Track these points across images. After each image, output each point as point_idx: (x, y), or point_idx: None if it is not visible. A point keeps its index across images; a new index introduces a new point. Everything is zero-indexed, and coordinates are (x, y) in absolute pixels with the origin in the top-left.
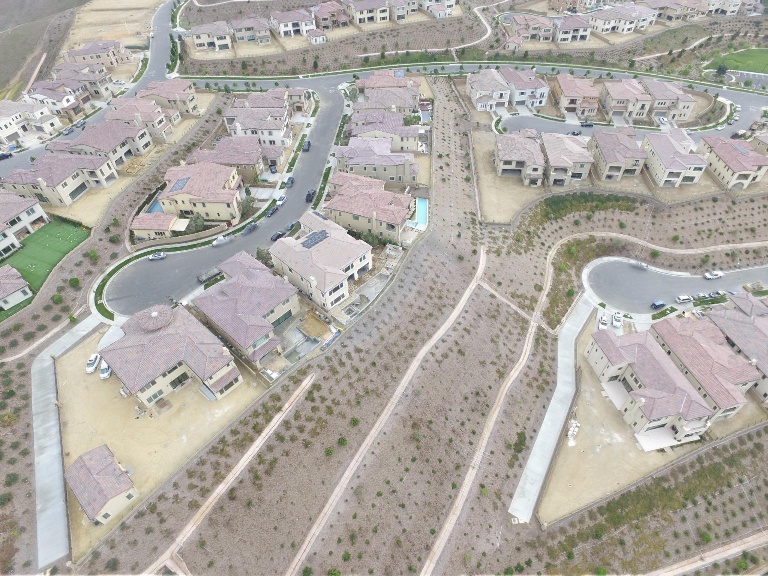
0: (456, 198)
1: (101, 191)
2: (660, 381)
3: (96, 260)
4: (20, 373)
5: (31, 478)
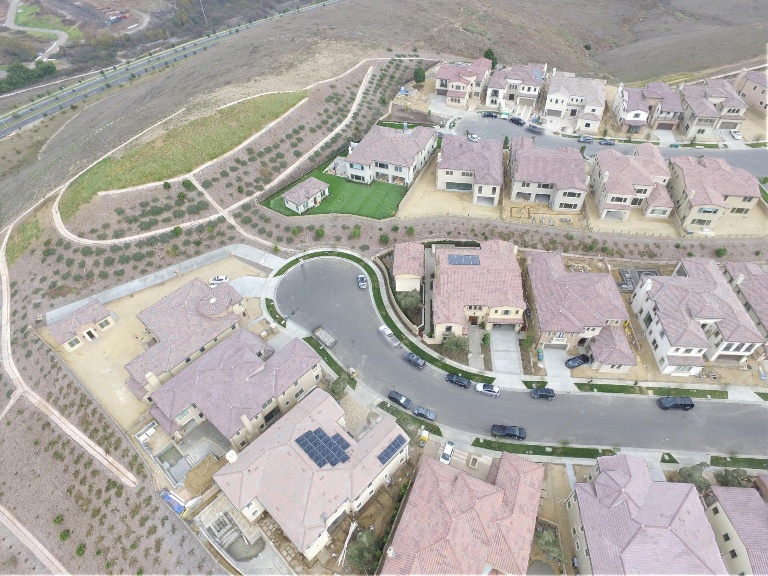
0: None
1: (467, 202)
2: None
3: (354, 237)
4: (223, 241)
5: (120, 283)
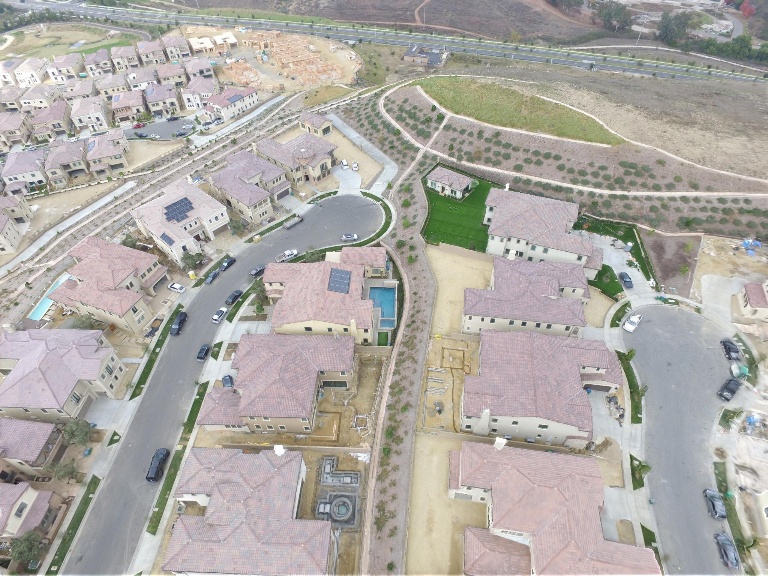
0: None
1: None
2: None
3: None
4: (399, 159)
5: None
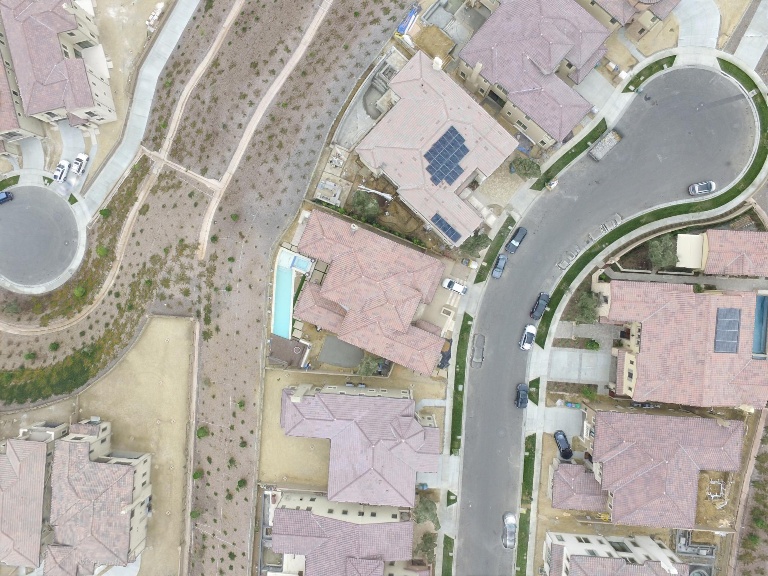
0: (227, 363)
1: None
2: (38, 34)
3: None
4: None
5: None
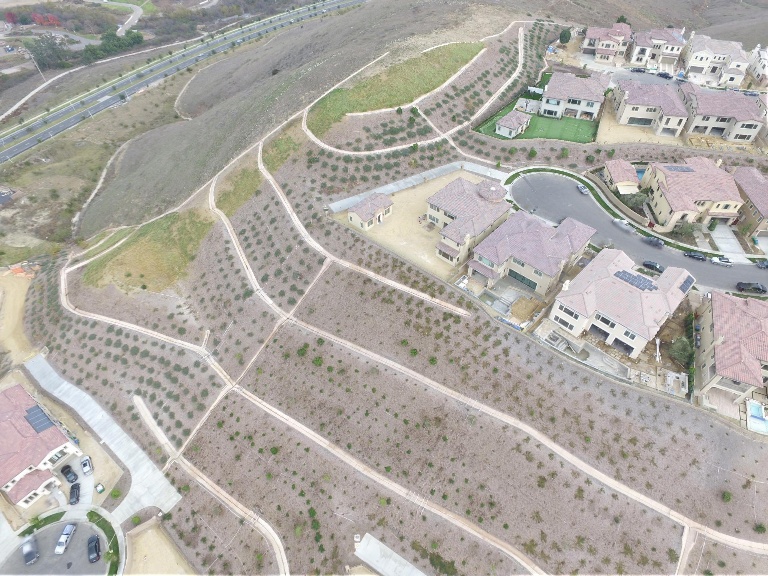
0: None
1: (650, 133)
2: None
3: (562, 157)
4: (449, 158)
5: (378, 186)
